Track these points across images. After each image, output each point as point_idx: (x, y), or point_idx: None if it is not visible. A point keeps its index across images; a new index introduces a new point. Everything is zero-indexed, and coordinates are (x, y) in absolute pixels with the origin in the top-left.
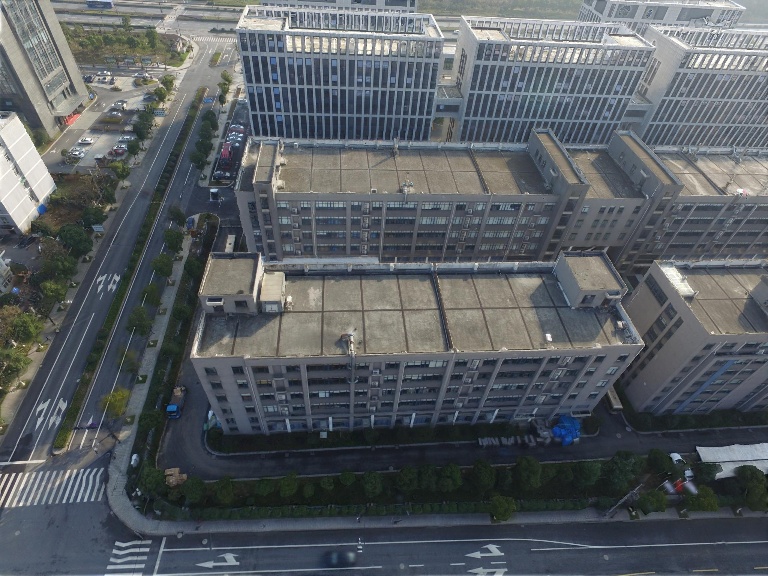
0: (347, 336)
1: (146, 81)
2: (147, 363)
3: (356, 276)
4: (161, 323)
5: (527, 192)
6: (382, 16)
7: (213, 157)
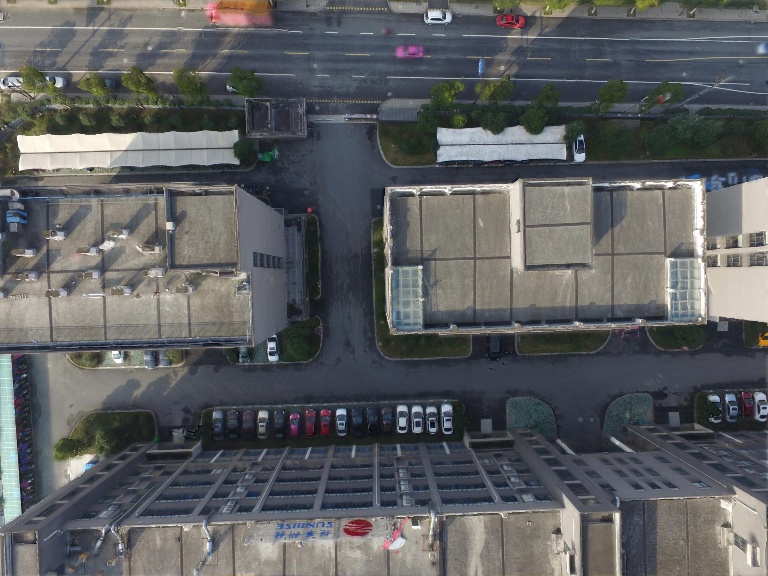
0: None
1: None
2: None
3: None
4: None
5: None
6: None
7: None
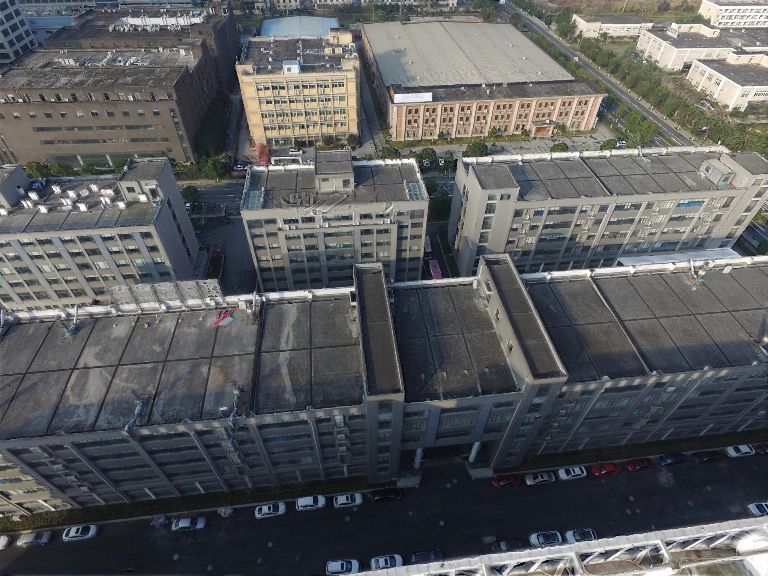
0: None
1: None
2: None
3: None
4: None
5: (549, 274)
6: None
7: None
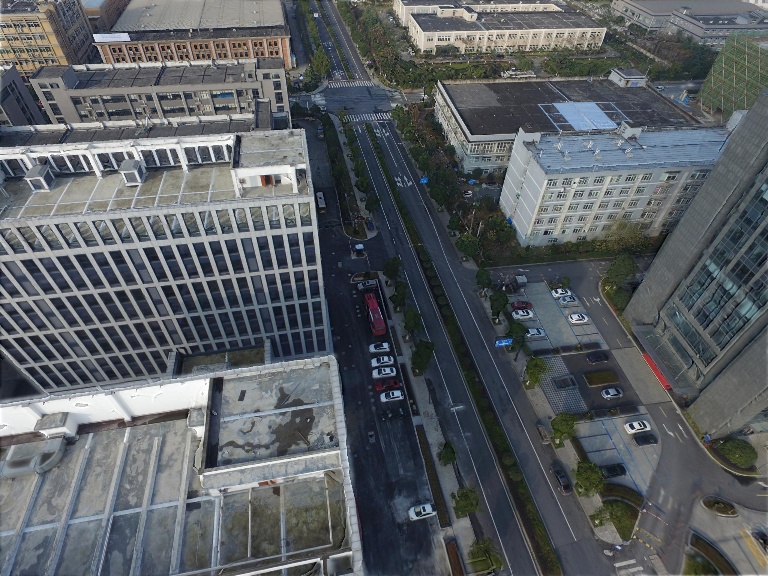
0: (214, 66)
1: (704, 569)
2: (347, 149)
3: None
4: (351, 164)
5: (30, 126)
6: (21, 225)
7: (397, 321)
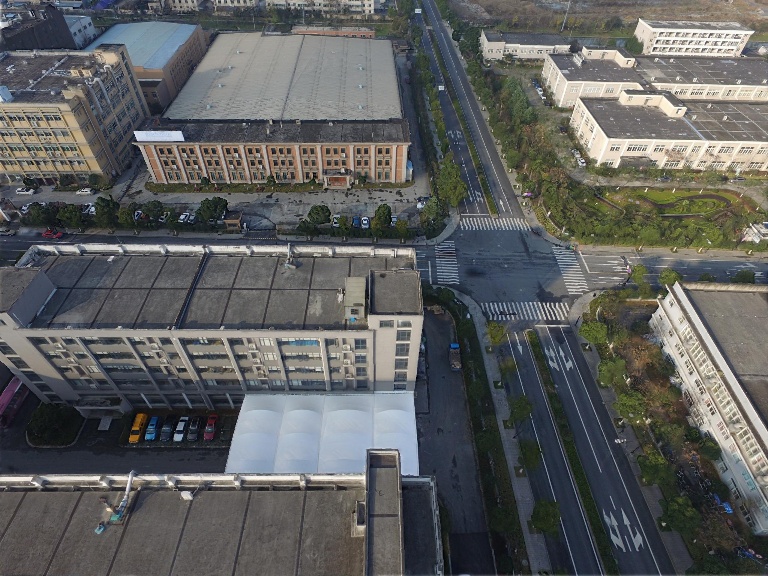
0: None
1: None
2: (502, 401)
3: (267, 328)
4: (513, 453)
5: None
6: None
7: None
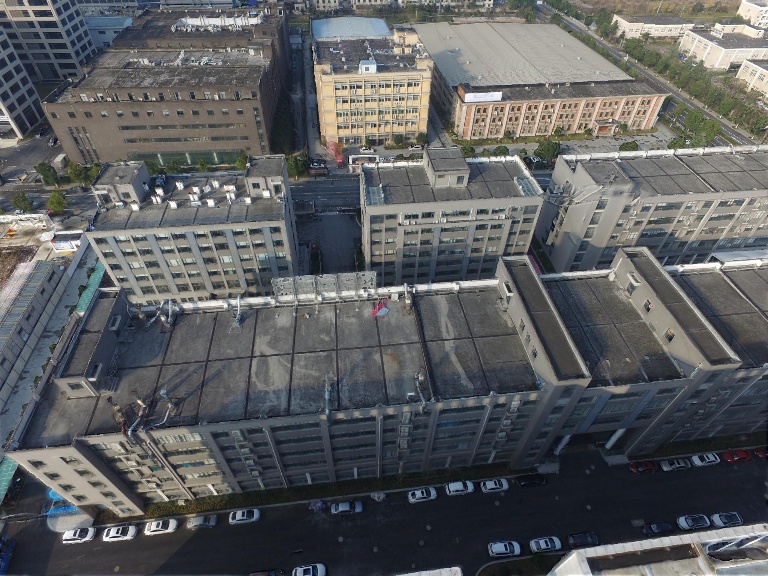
0: None
1: None
2: None
3: None
4: None
5: (683, 267)
6: None
7: None
